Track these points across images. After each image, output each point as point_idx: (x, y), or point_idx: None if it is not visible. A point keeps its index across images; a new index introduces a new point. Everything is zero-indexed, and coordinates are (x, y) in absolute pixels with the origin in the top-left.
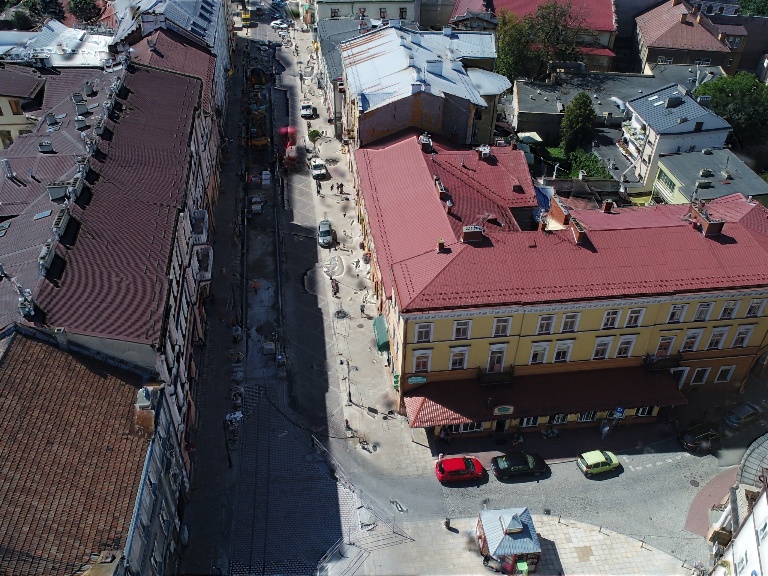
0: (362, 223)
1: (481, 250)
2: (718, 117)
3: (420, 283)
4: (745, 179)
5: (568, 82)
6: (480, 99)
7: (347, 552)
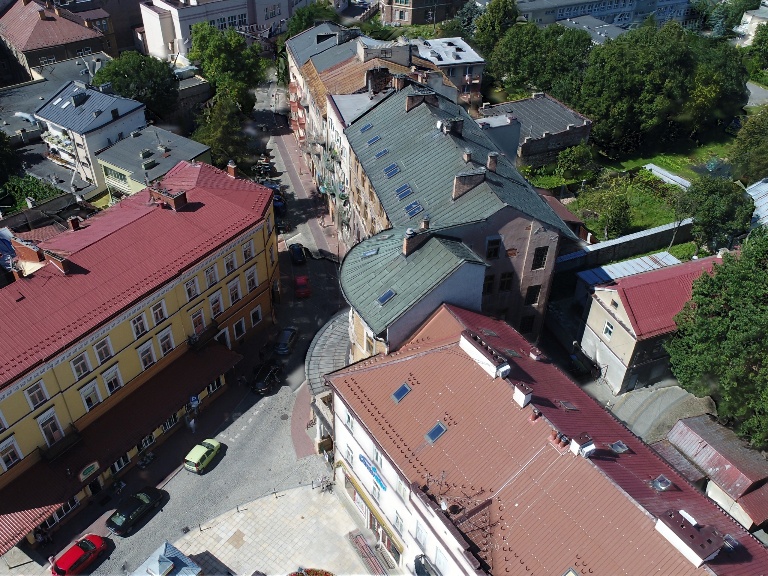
0: None
1: None
2: (127, 100)
3: None
4: (180, 146)
5: None
6: None
7: None
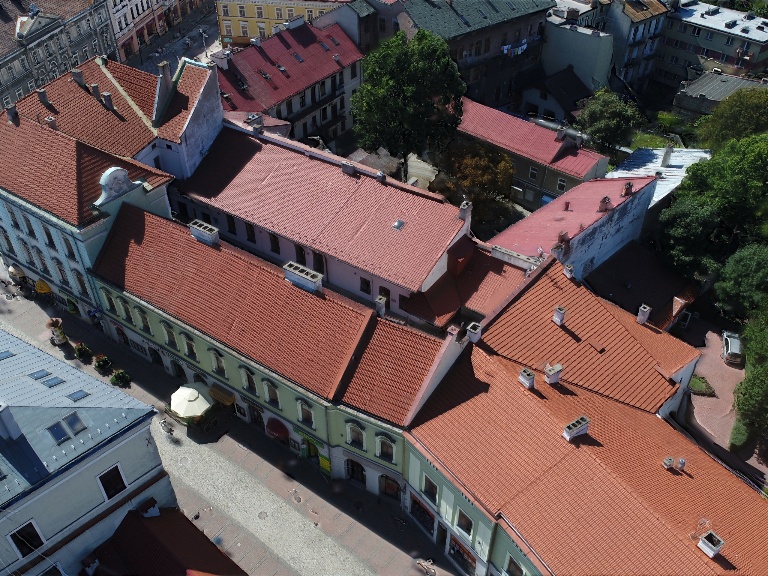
0: None
1: None
2: None
3: None
4: None
5: None
6: None
7: None
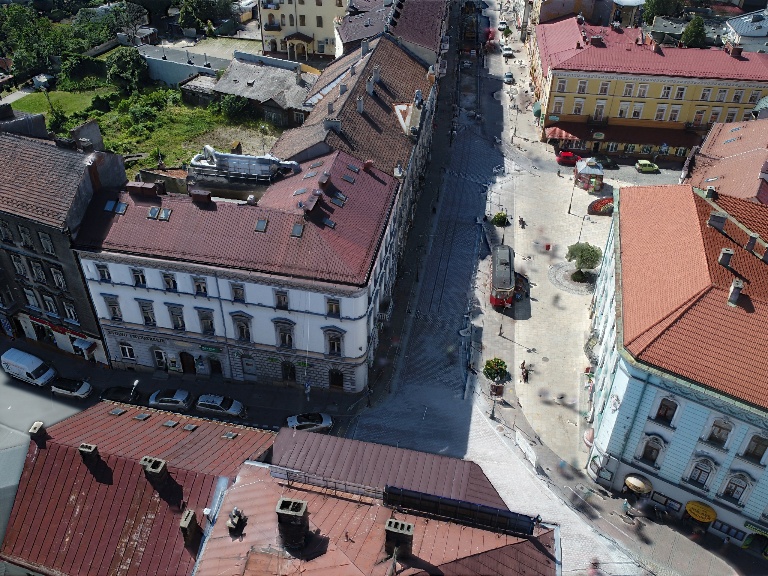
0: None
1: (600, 48)
2: None
3: (564, 59)
4: None
5: None
6: (620, 2)
7: (507, 175)
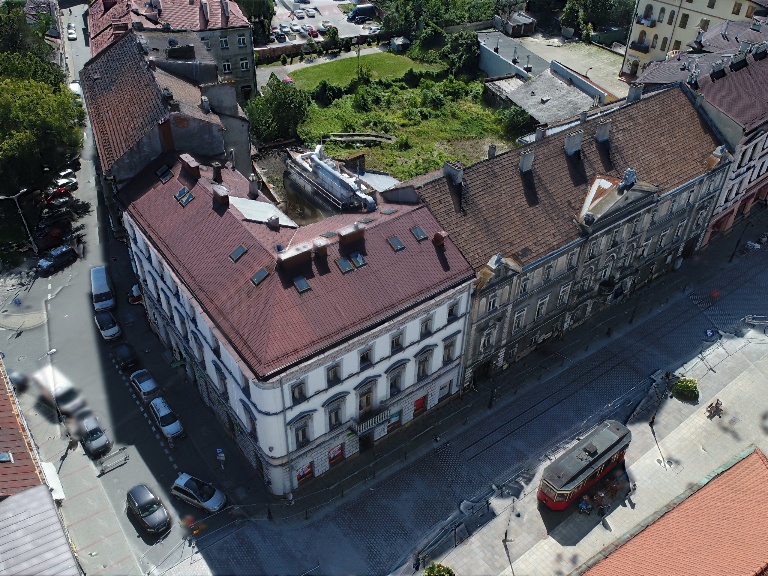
0: None
1: None
2: None
3: None
4: None
5: None
6: None
7: None
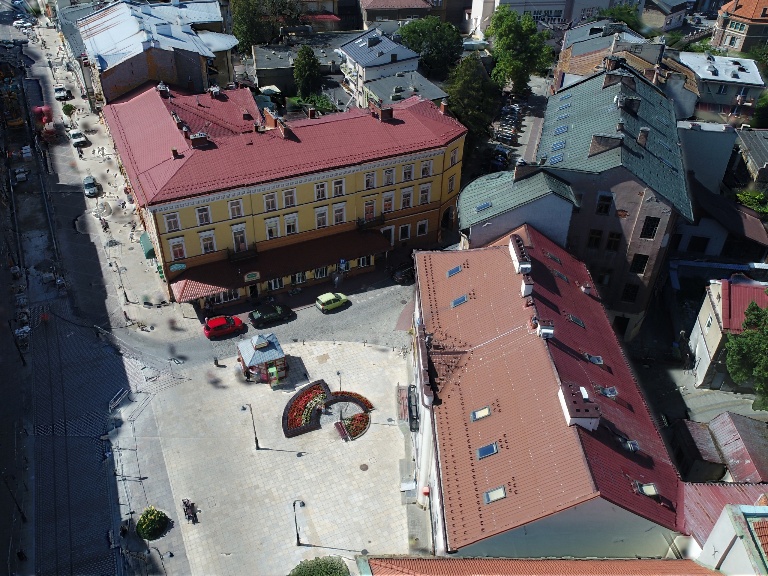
0: (123, 172)
1: (208, 152)
2: (407, 49)
3: (161, 183)
4: (427, 90)
5: (299, 43)
6: (209, 52)
7: (136, 398)
